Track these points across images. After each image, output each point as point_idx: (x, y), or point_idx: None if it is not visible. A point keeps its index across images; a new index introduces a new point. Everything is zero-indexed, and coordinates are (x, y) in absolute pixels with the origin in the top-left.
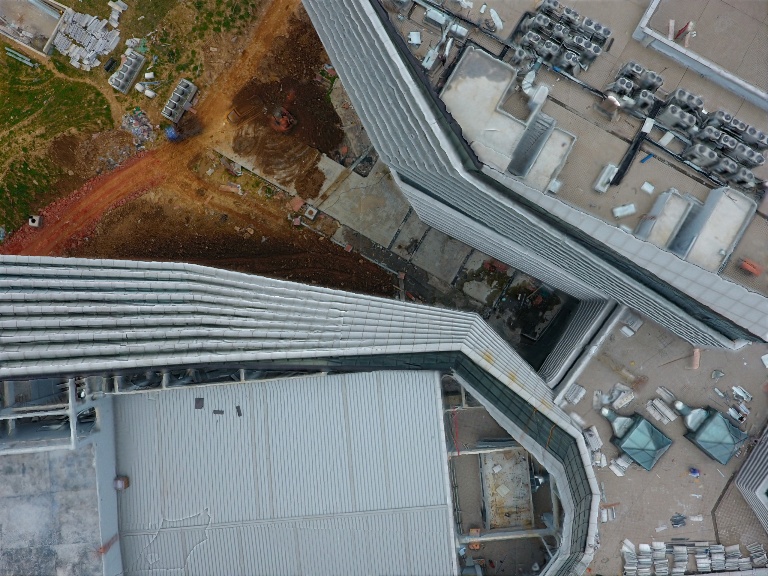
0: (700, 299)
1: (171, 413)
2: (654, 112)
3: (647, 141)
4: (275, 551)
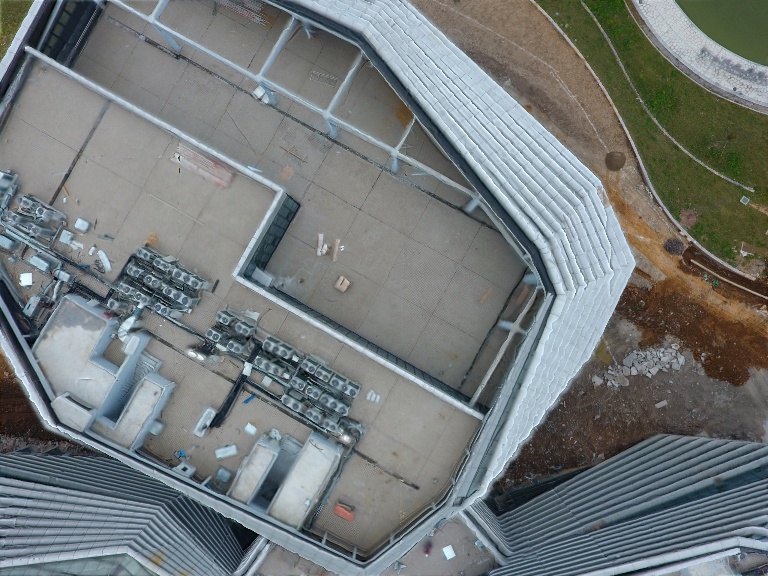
0: (287, 547)
1: None
2: (253, 356)
3: (247, 384)
4: None
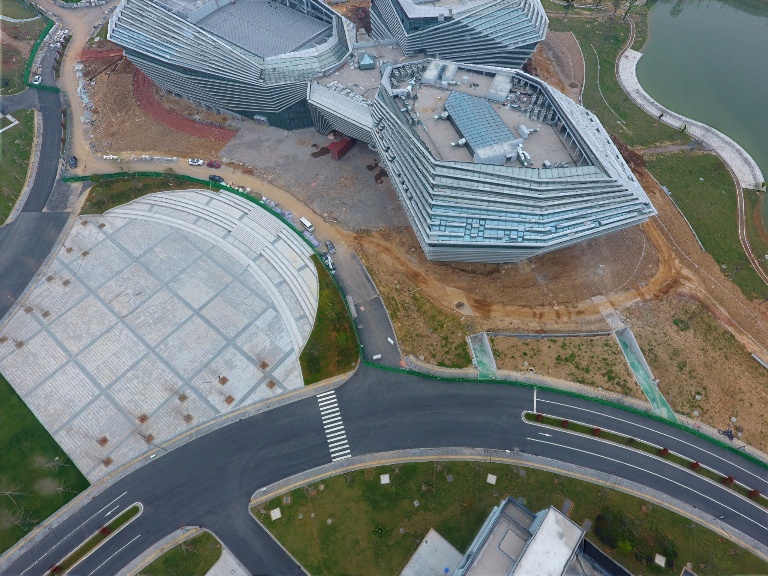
0: None
1: (260, 1)
2: None
3: None
4: None
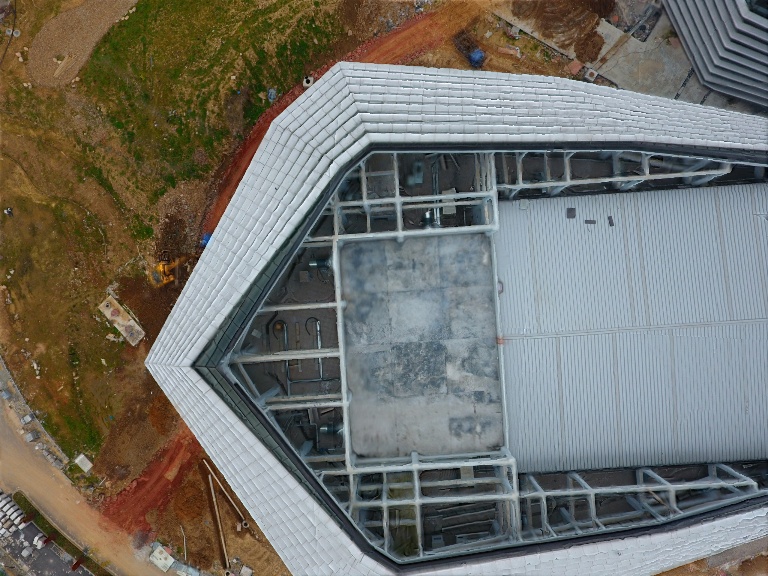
0: None
1: (542, 222)
2: None
3: None
4: (650, 359)
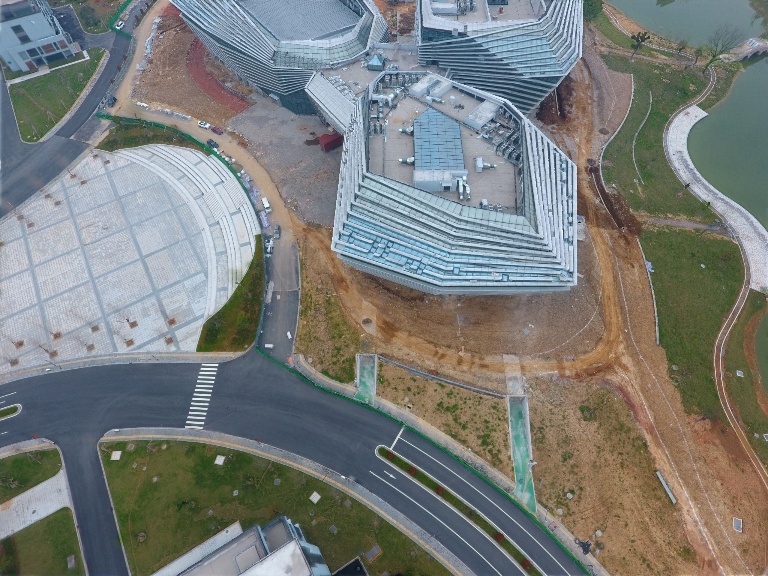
0: None
1: None
2: None
3: None
4: None
